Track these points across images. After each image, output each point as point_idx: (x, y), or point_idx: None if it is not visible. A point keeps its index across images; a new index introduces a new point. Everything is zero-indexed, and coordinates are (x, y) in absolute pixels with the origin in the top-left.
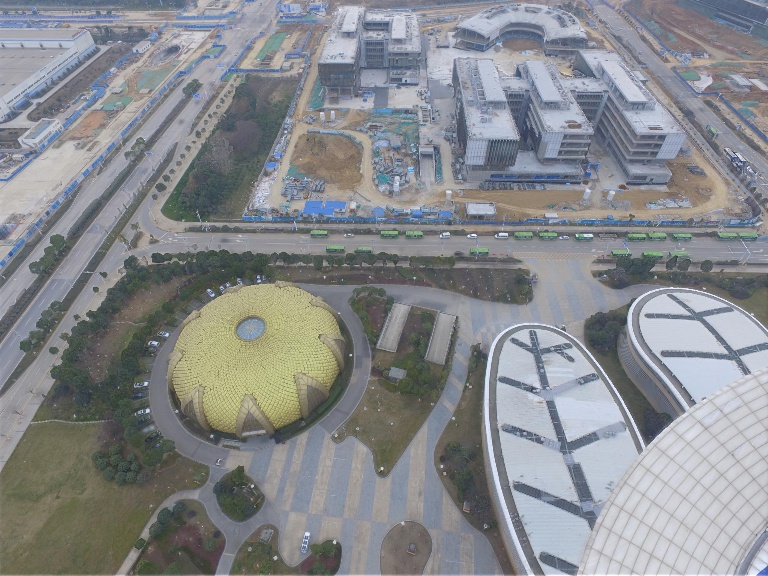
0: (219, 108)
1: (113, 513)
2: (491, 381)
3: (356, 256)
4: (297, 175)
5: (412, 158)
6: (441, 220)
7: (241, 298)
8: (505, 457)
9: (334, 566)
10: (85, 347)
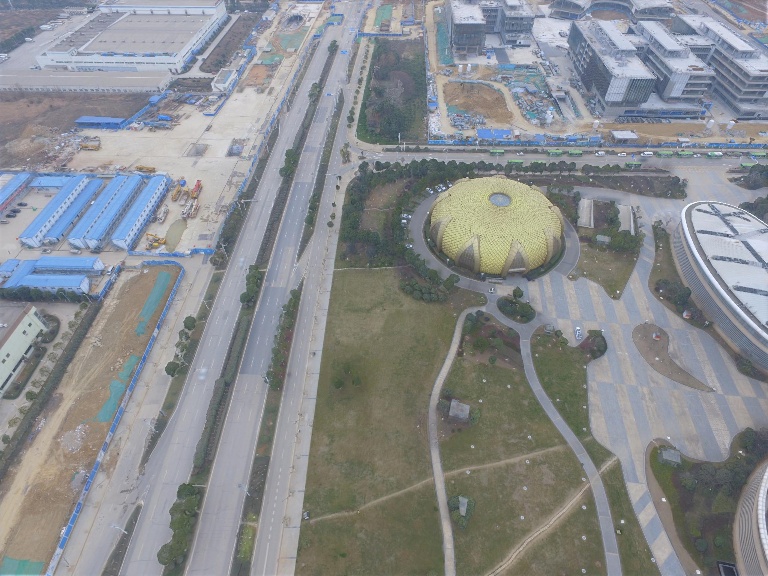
0: (365, 63)
1: (430, 318)
2: (691, 234)
3: (542, 164)
4: (458, 112)
5: (549, 100)
6: (594, 143)
7: (479, 183)
8: (721, 273)
9: (604, 346)
10: (360, 219)
